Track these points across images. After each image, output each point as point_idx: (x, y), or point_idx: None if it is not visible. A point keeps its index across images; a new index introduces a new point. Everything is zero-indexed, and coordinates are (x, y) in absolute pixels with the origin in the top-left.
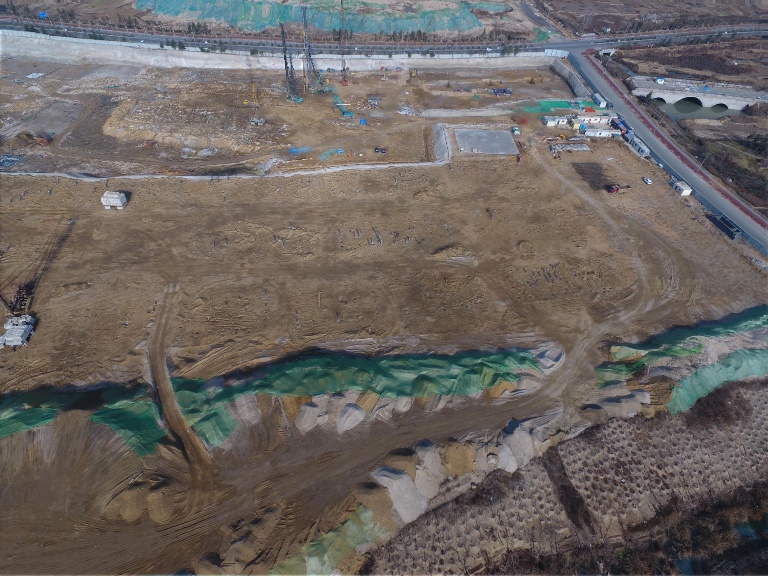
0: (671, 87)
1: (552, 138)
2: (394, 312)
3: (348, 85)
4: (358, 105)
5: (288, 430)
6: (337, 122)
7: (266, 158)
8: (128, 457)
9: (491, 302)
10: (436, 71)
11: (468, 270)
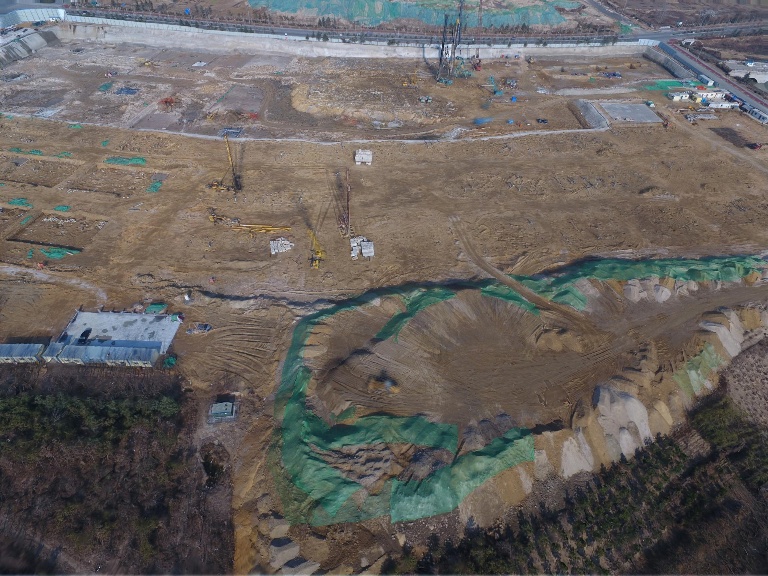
0: (761, 69)
1: (683, 109)
2: (636, 232)
3: (481, 70)
4: (500, 86)
5: (624, 301)
6: (492, 99)
7: (450, 128)
8: (528, 316)
9: (705, 225)
10: (548, 59)
11: (674, 204)
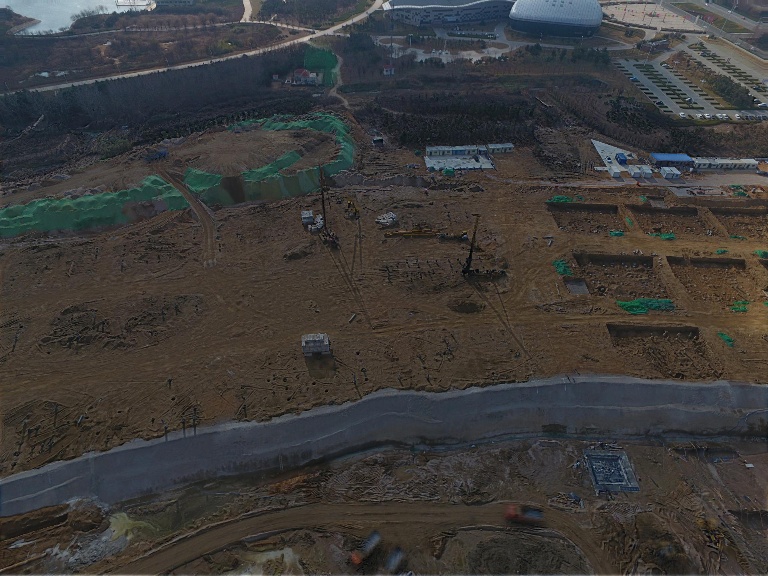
0: None
1: None
2: (4, 265)
3: None
4: None
5: (111, 185)
6: None
7: (96, 568)
8: None
9: None
10: None
11: None
